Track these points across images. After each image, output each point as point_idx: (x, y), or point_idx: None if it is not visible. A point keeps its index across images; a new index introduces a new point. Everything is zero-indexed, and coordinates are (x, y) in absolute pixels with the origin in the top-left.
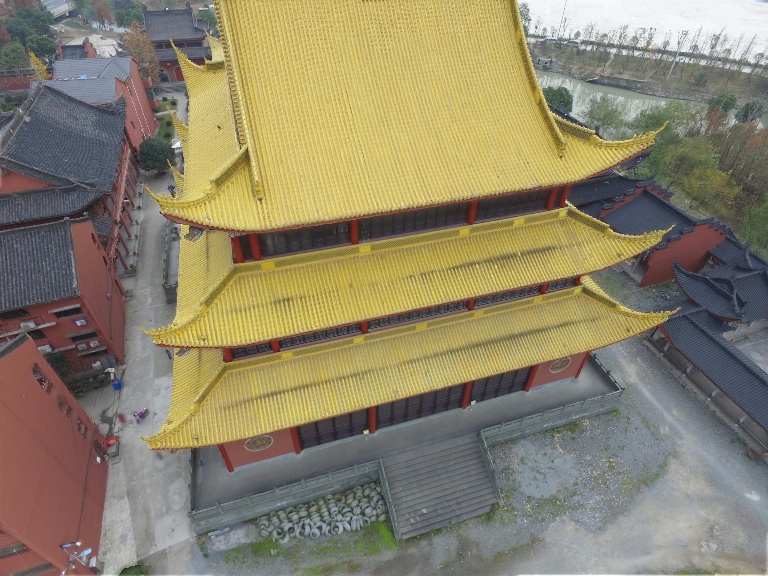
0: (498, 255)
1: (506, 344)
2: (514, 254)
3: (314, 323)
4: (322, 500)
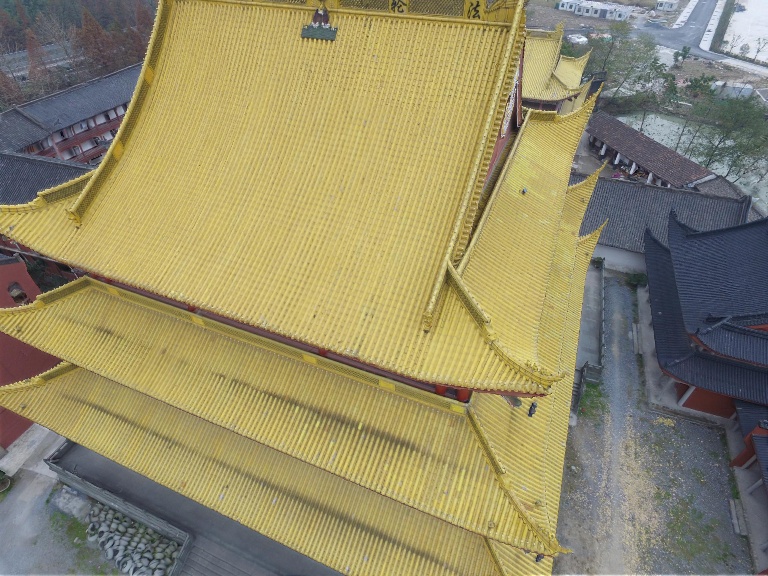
0: (332, 411)
1: (330, 521)
2: (354, 422)
3: (107, 368)
4: (143, 529)
